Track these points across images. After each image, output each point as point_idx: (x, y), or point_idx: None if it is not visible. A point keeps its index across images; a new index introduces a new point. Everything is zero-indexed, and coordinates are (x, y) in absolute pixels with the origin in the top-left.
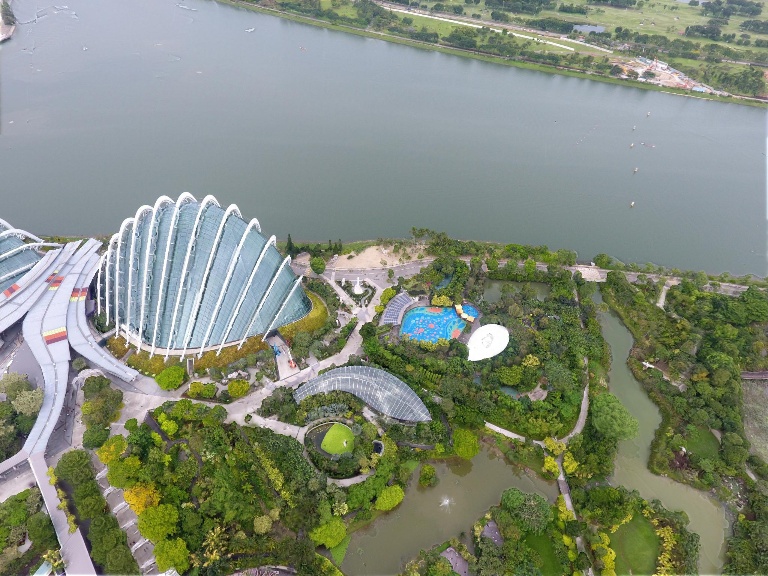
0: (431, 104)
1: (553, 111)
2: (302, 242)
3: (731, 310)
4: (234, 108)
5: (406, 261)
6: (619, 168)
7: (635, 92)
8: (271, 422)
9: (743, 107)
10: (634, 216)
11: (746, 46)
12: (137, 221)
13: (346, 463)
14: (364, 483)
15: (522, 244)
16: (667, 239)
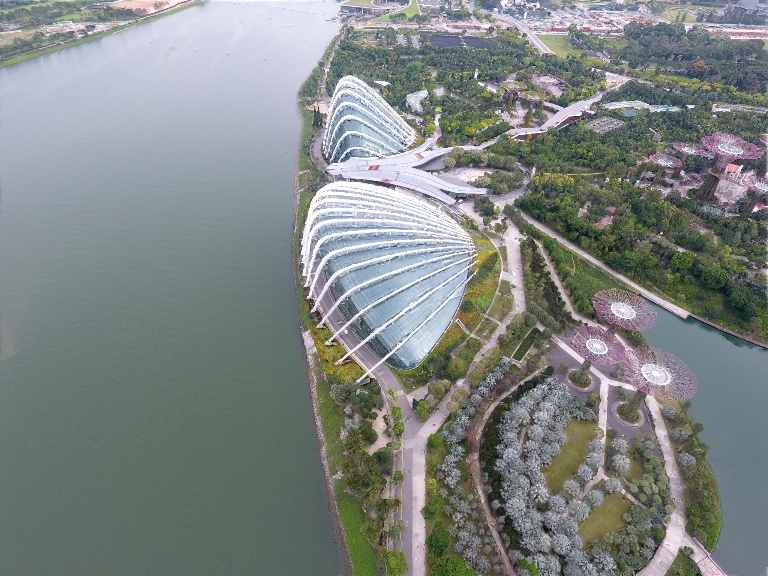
0: (86, 94)
1: (128, 61)
2: (301, 130)
3: (356, 48)
4: (25, 182)
5: (321, 102)
6: (222, 57)
7: (95, 43)
8: (436, 119)
9: (140, 27)
10: (274, 61)
11: (49, 1)
12: (356, 105)
13: (450, 101)
14: (455, 100)
15: (302, 81)
16: (294, 58)
